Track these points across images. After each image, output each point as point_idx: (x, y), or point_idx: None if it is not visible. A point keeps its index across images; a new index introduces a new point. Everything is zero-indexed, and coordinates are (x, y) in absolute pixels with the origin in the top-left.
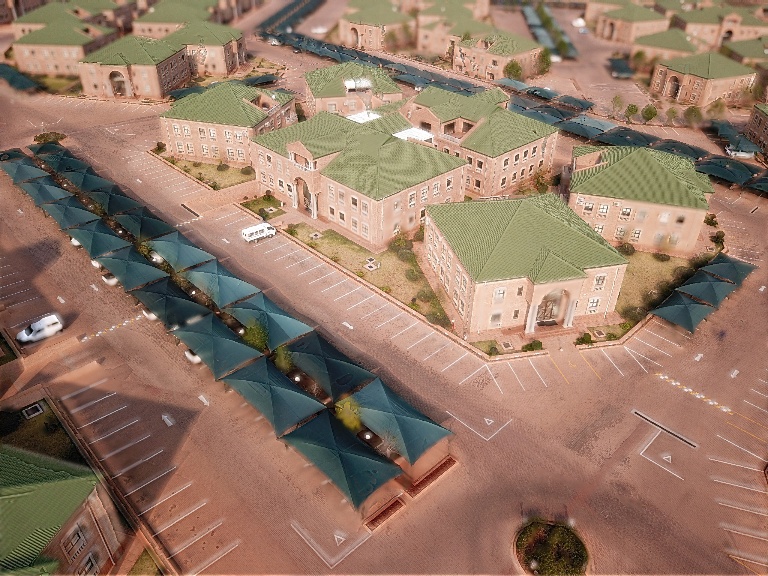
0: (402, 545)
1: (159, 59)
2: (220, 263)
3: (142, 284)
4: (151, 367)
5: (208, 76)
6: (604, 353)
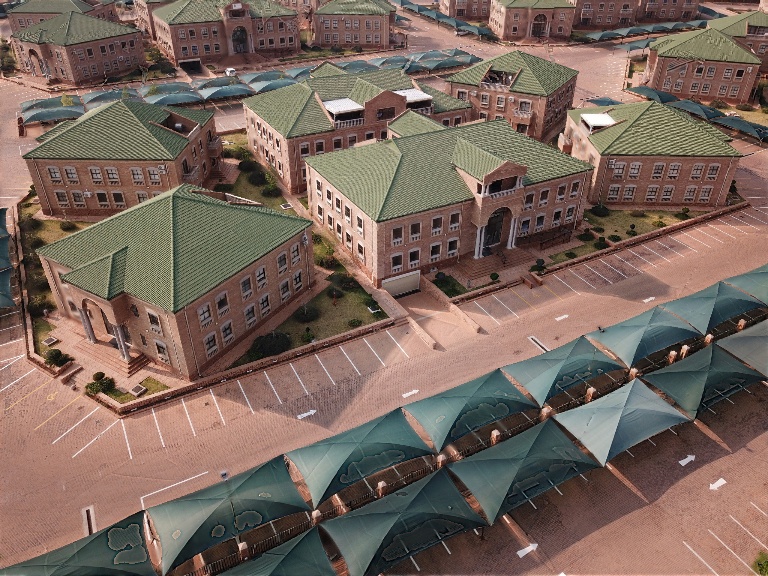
0: (3, 122)
1: (676, 54)
2: (247, 92)
3: None
4: None
5: (766, 112)
6: (18, 197)
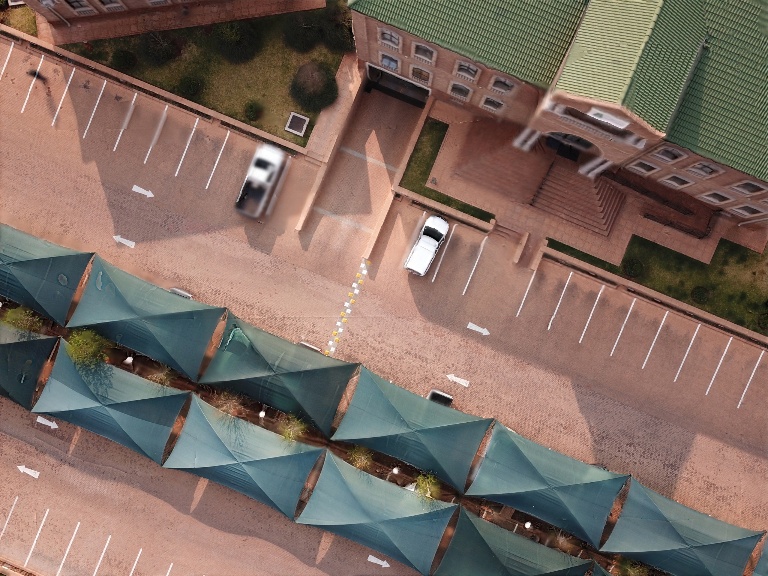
0: None
1: None
2: (274, 507)
3: (354, 395)
4: (233, 263)
5: None
6: None
